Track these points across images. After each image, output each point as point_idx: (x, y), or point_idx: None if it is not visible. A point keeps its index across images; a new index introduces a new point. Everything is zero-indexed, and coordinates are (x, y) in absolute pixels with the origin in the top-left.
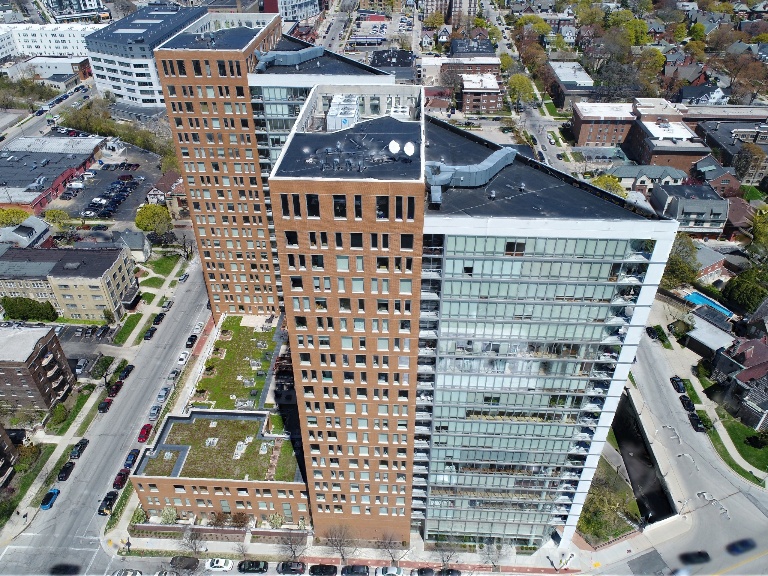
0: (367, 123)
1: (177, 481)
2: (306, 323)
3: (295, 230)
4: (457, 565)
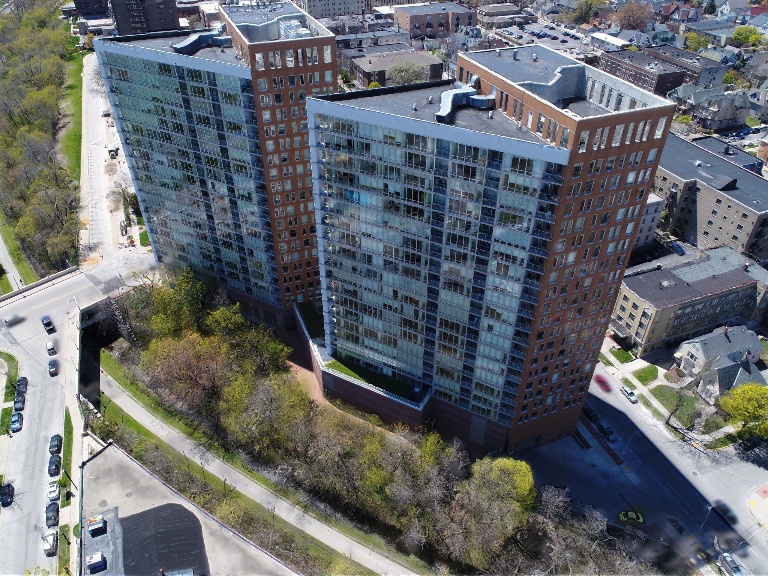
0: (268, 21)
1: None
2: None
3: None
4: None
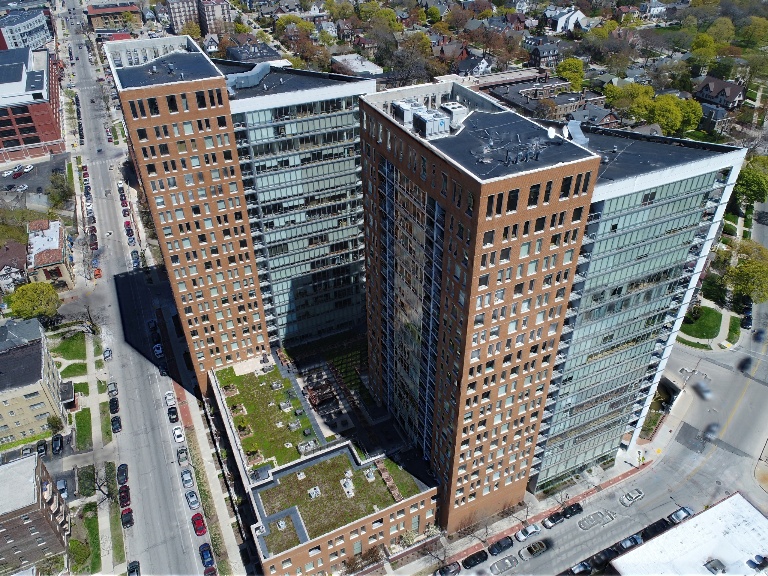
0: (468, 121)
1: (314, 543)
2: (483, 319)
3: (494, 229)
4: (571, 500)
